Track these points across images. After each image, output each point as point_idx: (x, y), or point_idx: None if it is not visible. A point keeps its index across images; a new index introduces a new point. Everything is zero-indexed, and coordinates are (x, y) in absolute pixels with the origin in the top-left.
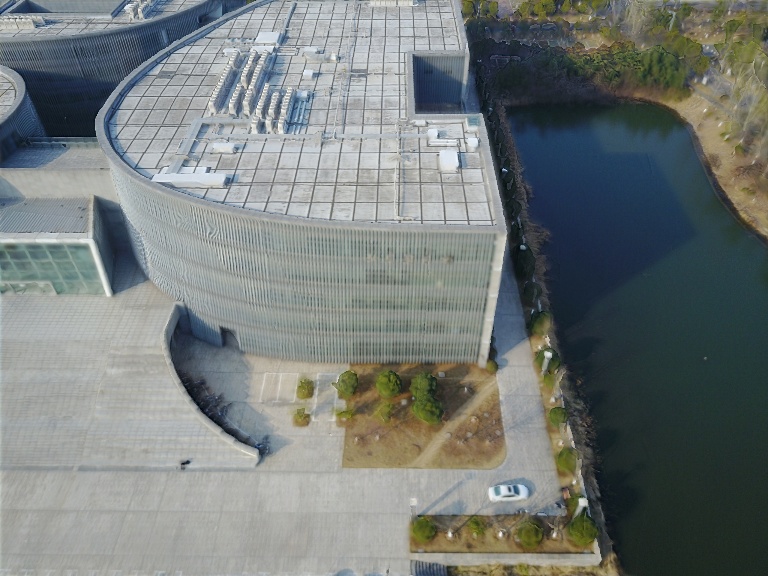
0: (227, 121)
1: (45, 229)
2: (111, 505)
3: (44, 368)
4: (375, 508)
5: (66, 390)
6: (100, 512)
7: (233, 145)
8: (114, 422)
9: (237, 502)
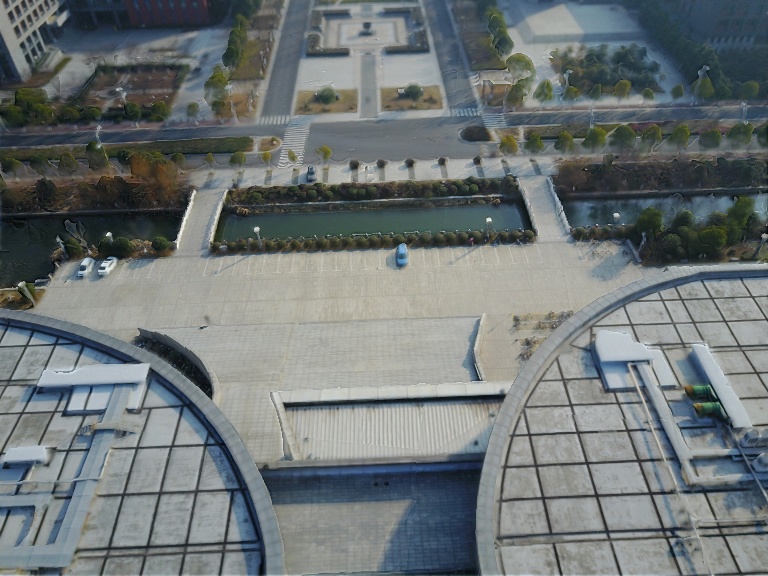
0: (0, 550)
1: (350, 414)
2: (260, 304)
3: (346, 372)
4: (59, 311)
5: (317, 358)
6: (267, 300)
7: (8, 452)
8: (268, 344)
9: (164, 310)
